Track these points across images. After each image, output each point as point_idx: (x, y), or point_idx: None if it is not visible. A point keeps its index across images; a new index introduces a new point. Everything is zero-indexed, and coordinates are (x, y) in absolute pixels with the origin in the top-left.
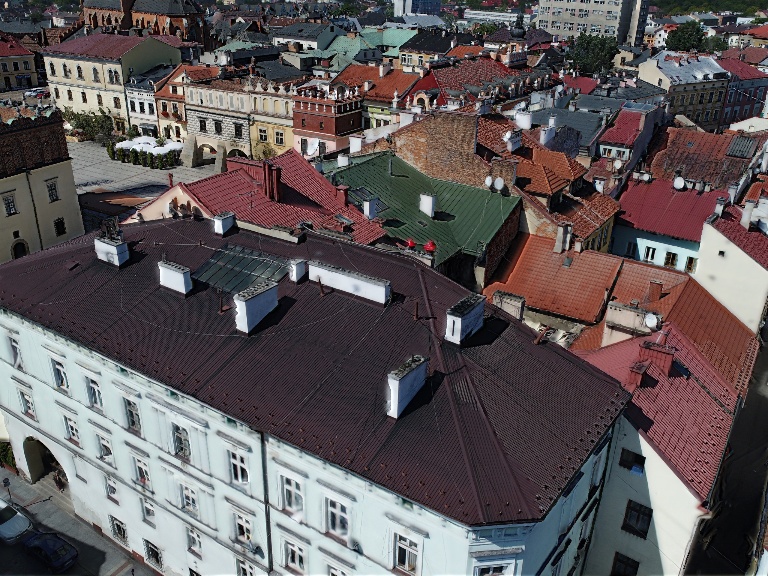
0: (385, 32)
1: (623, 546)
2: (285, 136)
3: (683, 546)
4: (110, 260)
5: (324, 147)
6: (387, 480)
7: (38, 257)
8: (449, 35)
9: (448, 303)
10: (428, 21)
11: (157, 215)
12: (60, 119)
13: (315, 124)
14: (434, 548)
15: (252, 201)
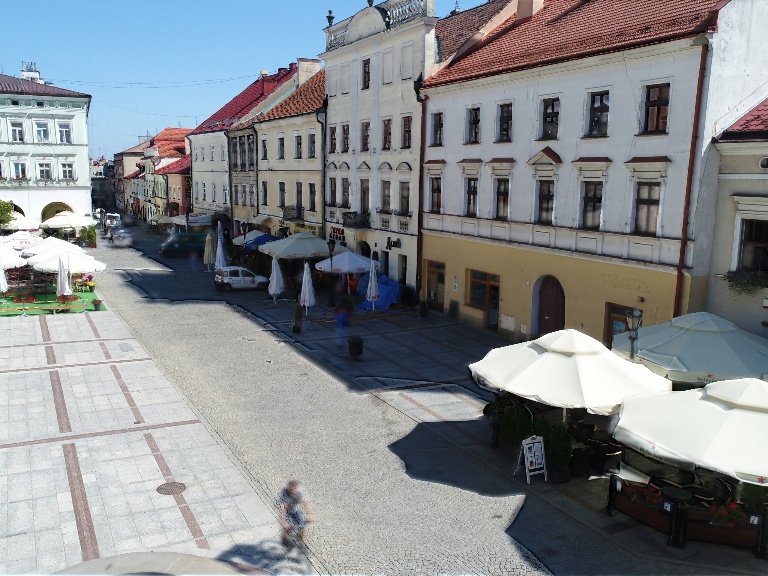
0: None
1: None
2: None
3: None
4: None
5: None
6: None
7: (49, 87)
8: None
9: None
10: None
11: None
12: None
13: None
14: None
15: None
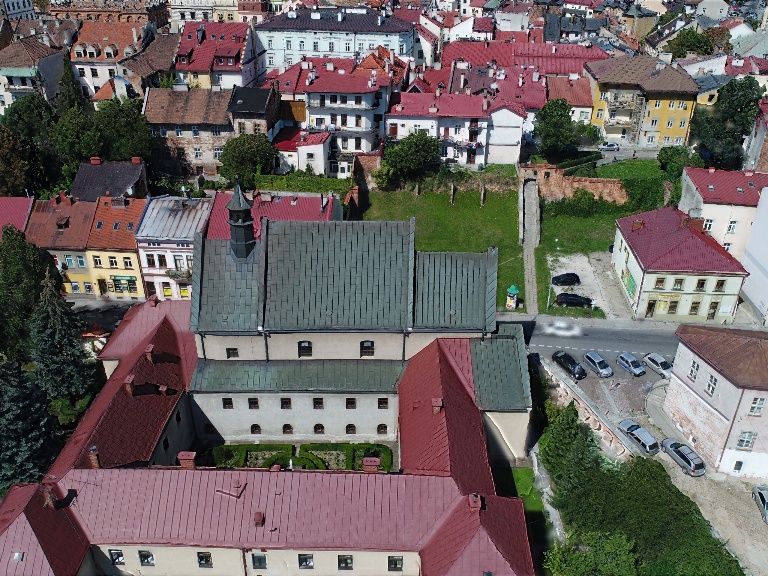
0: None
1: (419, 63)
2: (234, 16)
3: (430, 57)
4: (293, 17)
5: (256, 18)
6: (384, 31)
7: None
8: None
9: (378, 13)
10: None
11: None
12: (166, 5)
13: (251, 8)
14: (393, 43)
15: (312, 5)
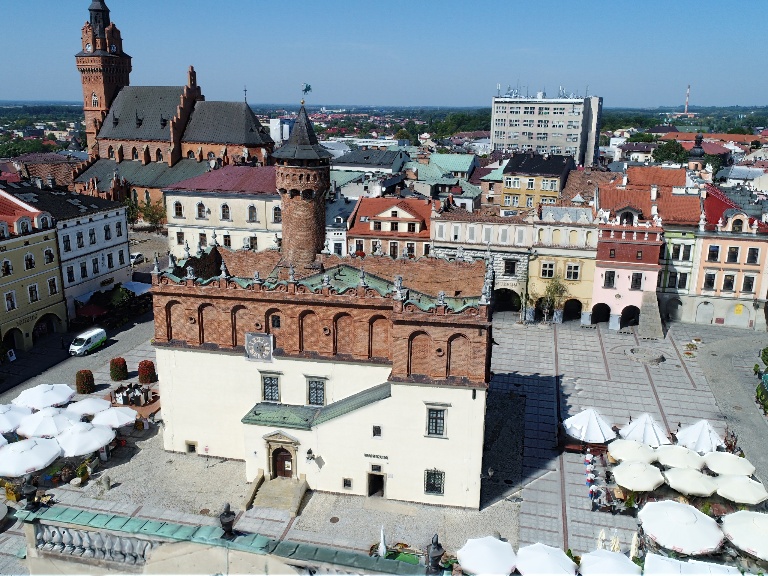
0: (431, 157)
1: None
2: (582, 269)
3: None
4: None
5: (638, 278)
6: None
7: None
8: (550, 158)
9: None
10: (337, 148)
11: None
12: None
13: (630, 254)
14: None
15: None
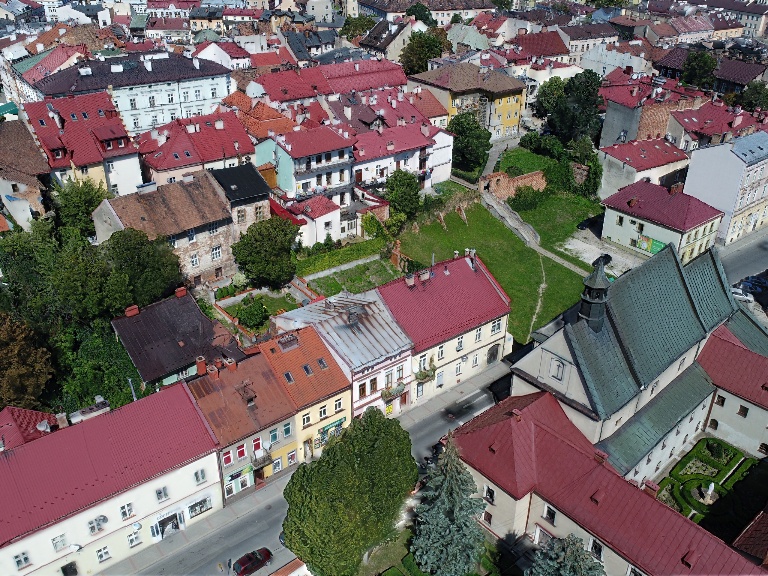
0: None
1: None
2: None
3: None
4: None
5: None
6: (210, 75)
7: (57, 83)
8: None
9: None
10: None
11: (67, 66)
12: None
13: None
14: None
15: None
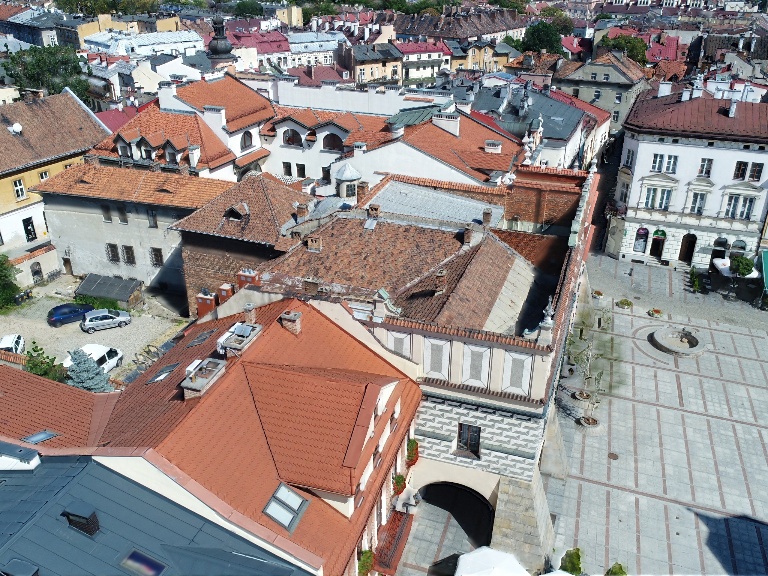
0: None
1: None
2: None
3: None
4: None
5: None
6: None
7: None
8: None
9: None
10: None
11: None
12: None
13: None
14: None
15: None
